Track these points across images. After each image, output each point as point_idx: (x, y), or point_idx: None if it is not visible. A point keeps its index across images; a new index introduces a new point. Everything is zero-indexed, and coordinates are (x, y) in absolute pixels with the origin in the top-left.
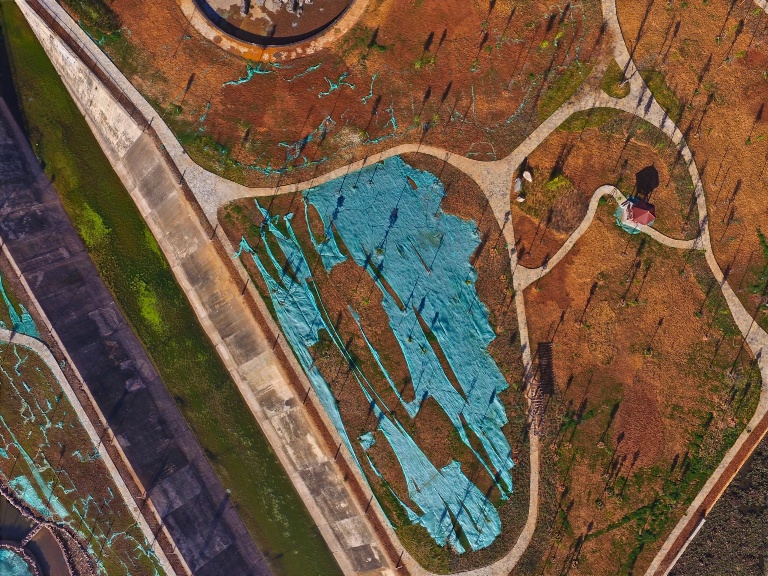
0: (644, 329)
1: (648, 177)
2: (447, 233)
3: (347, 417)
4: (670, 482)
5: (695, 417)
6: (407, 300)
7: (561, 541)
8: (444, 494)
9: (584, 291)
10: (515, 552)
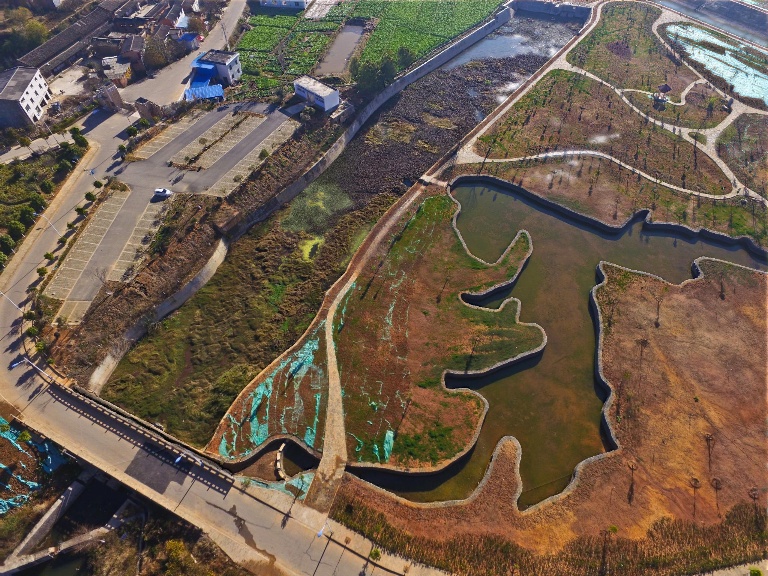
0: None
1: (660, 108)
2: (753, 93)
3: None
4: None
5: None
6: None
7: None
8: None
9: None
10: (657, 25)
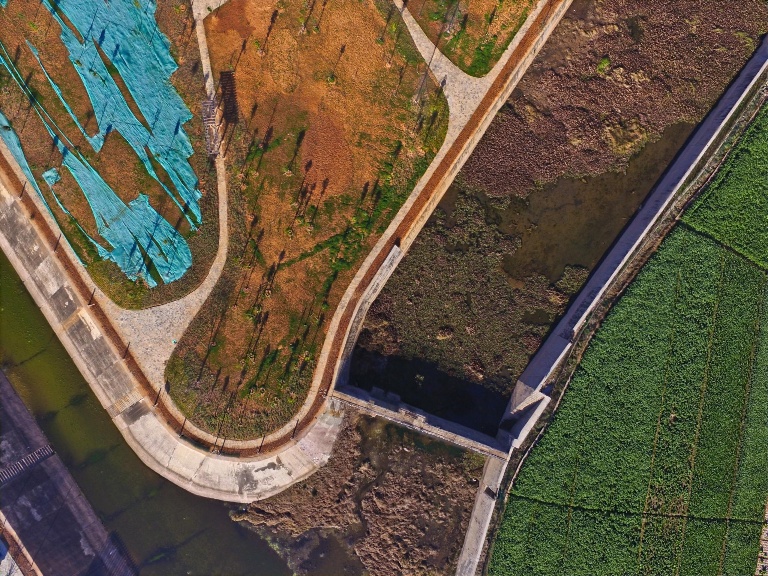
0: (327, 57)
1: None
2: None
3: (30, 154)
4: (361, 210)
5: (383, 145)
6: (87, 33)
7: (253, 271)
8: (133, 228)
9: (265, 20)
10: (207, 283)
